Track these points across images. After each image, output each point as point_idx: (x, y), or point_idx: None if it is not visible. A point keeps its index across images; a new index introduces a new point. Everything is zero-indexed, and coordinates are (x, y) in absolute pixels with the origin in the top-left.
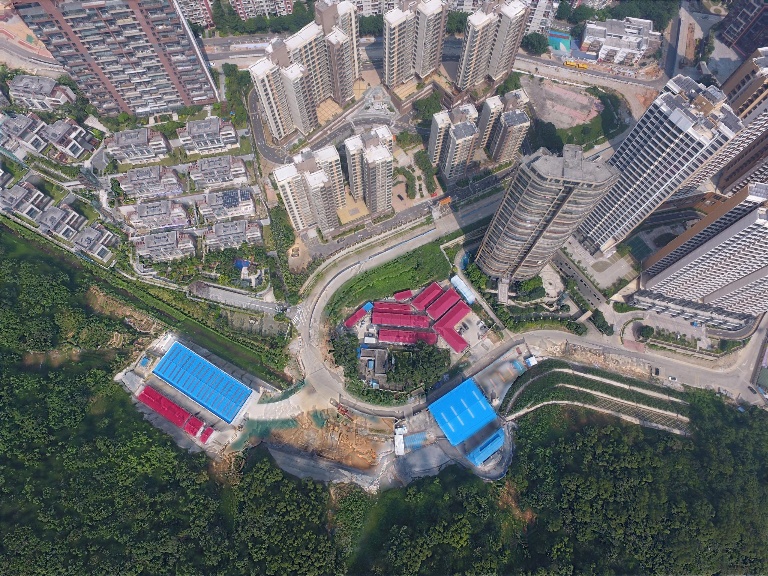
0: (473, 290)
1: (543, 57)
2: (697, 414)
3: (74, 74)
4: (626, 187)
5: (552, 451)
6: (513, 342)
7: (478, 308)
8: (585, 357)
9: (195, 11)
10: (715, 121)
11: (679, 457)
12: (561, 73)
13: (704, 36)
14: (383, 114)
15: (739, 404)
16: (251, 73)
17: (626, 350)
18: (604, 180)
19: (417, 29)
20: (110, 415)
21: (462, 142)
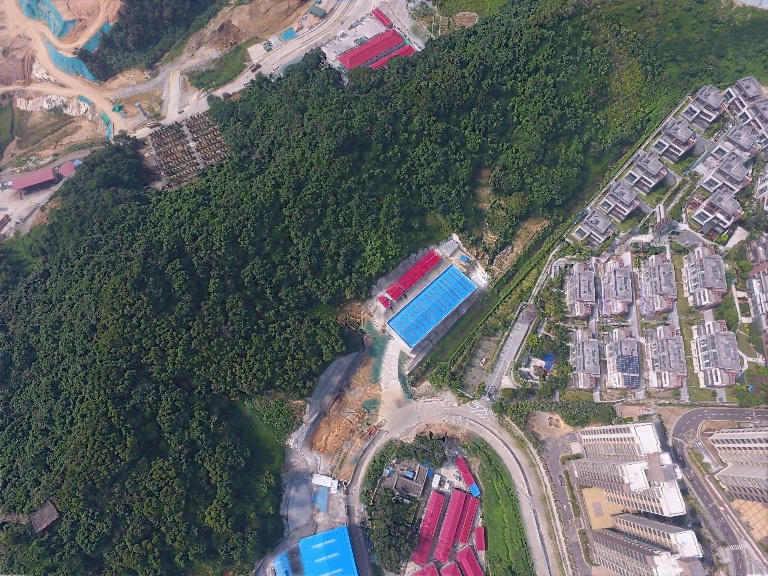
0: None
1: None
2: None
3: None
4: None
5: None
6: None
7: None
8: None
9: None
10: None
11: None
12: None
13: None
14: None
15: None
16: None
17: None
18: None
19: None
20: (423, 228)
21: None
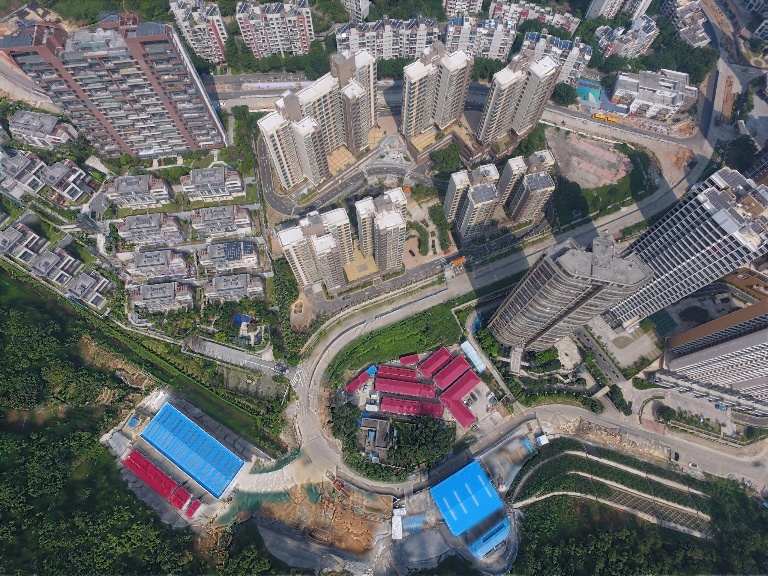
0: (484, 357)
1: (570, 108)
2: (719, 512)
3: (75, 118)
4: (657, 274)
5: (561, 551)
6: (524, 417)
7: (488, 379)
8: (600, 437)
9: (207, 48)
10: (764, 224)
11: (700, 569)
12: (589, 126)
13: (743, 91)
14: (398, 163)
15: (764, 498)
16: (260, 128)
17: (644, 431)
18: (637, 282)
19: (439, 82)
20: (93, 481)
21: (481, 206)
